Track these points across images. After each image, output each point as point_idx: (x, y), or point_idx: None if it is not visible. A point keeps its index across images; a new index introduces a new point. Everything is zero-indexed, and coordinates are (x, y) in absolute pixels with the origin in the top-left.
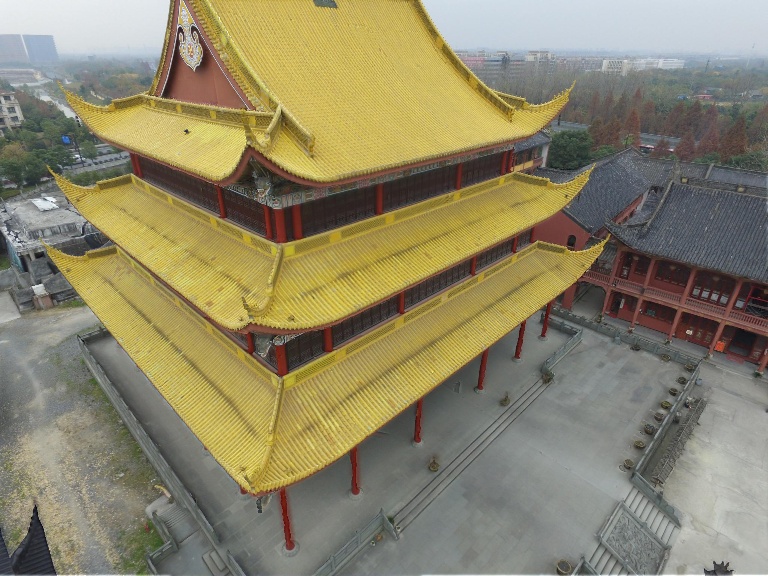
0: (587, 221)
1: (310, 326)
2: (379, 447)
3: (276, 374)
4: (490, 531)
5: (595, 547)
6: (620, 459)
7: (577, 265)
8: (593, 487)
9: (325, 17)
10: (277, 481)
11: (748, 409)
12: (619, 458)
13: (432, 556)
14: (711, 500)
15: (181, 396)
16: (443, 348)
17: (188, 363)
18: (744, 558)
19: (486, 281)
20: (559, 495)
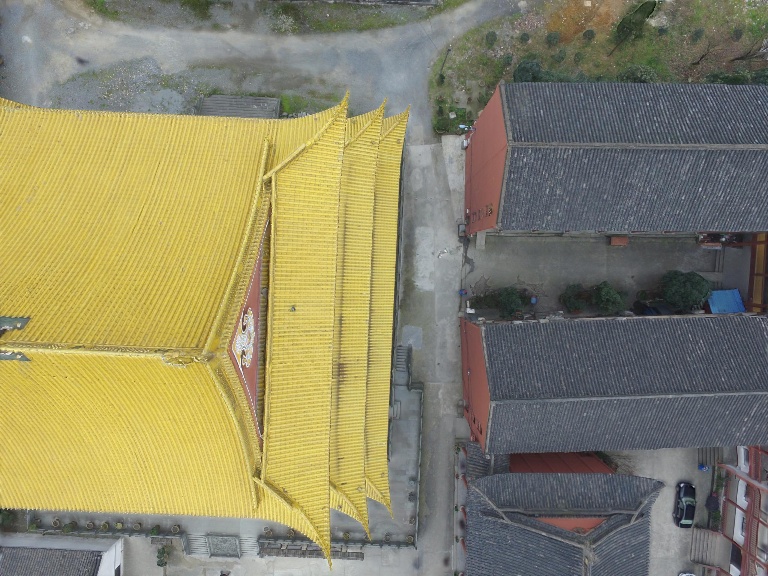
0: (511, 442)
1: None
2: None
3: None
4: None
5: (202, 535)
6: (273, 526)
7: None
8: (239, 520)
9: (7, 368)
10: None
11: (406, 572)
12: (273, 525)
13: None
14: (294, 567)
15: None
16: None
17: None
18: None
19: None
20: None
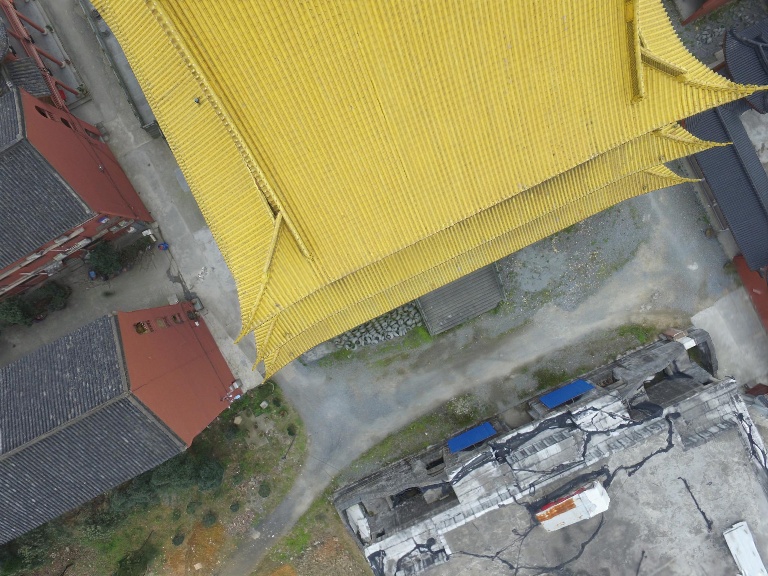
0: None
1: None
2: None
3: None
4: None
5: None
6: None
7: None
8: None
9: None
10: None
11: None
12: None
13: None
14: None
15: None
16: None
17: None
18: None
19: None
20: None
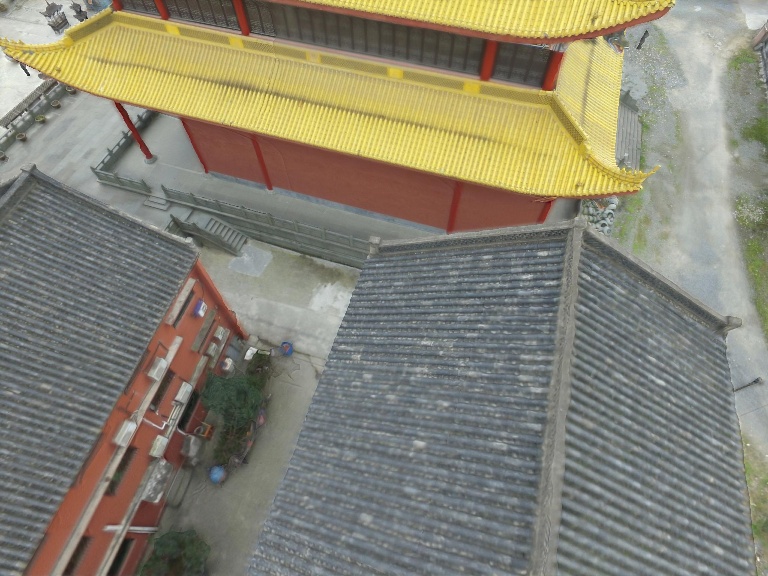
0: None
1: None
2: None
3: None
4: None
5: None
6: None
7: None
8: None
9: None
10: None
11: None
12: None
13: None
14: None
15: None
16: None
17: None
18: None
19: None
20: None
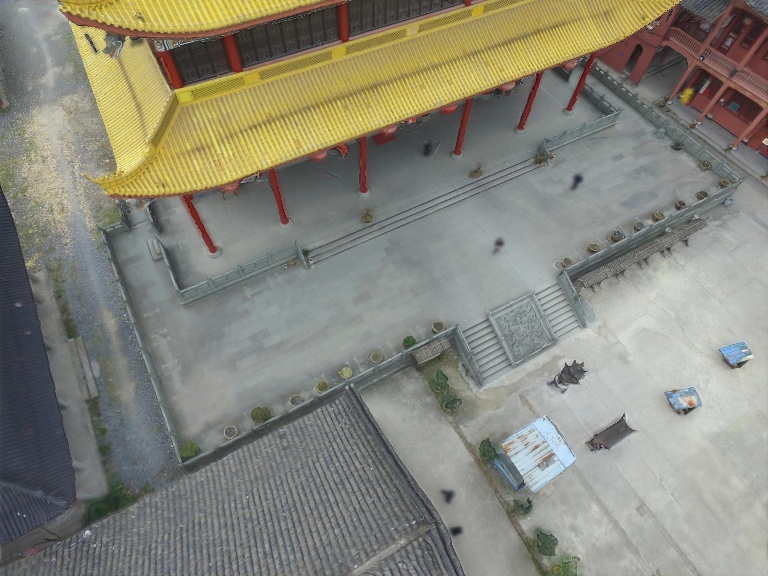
0: None
1: (165, 31)
2: (325, 188)
3: (169, 86)
4: (392, 283)
5: (481, 320)
6: (563, 256)
7: (636, 16)
8: (515, 273)
9: None
10: (140, 189)
11: (763, 244)
12: (562, 255)
13: (331, 288)
14: (636, 315)
15: (104, 93)
16: (386, 95)
17: (116, 59)
18: (626, 367)
19: (486, 18)
20: (476, 272)
